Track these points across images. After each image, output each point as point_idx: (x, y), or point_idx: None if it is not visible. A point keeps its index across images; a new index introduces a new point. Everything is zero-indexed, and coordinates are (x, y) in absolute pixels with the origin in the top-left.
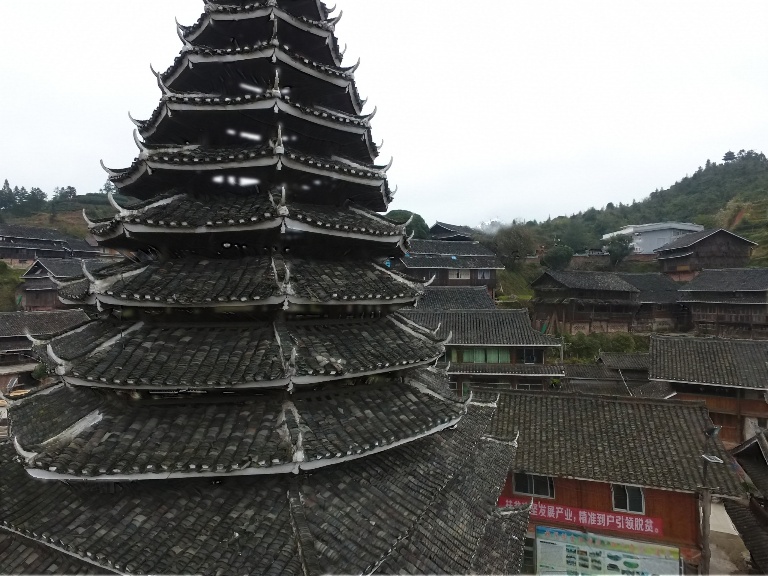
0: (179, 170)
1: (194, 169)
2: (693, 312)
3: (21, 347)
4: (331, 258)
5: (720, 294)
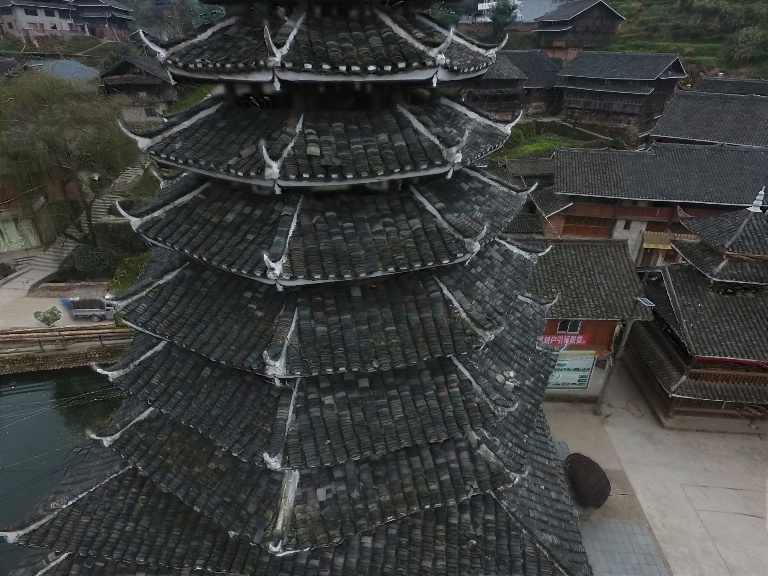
0: (320, 186)
1: (341, 184)
2: (566, 97)
3: None
4: None
5: (592, 80)
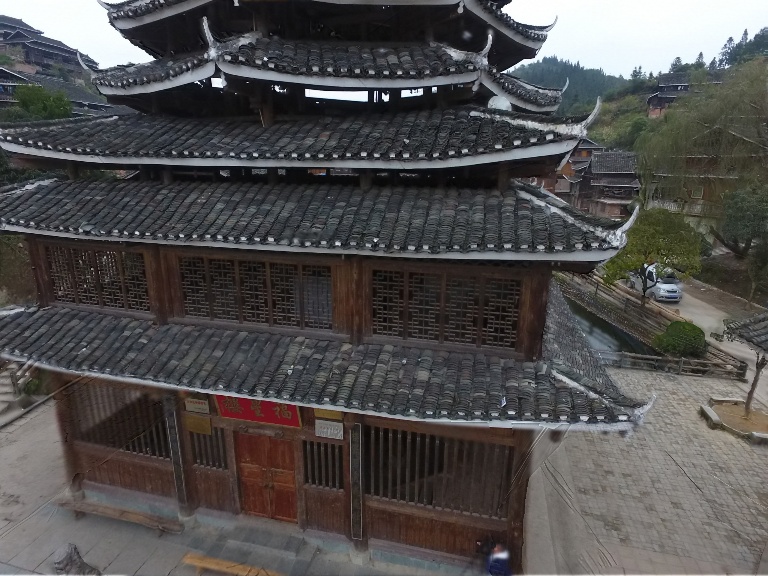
0: None
1: None
2: None
3: None
4: None
5: None
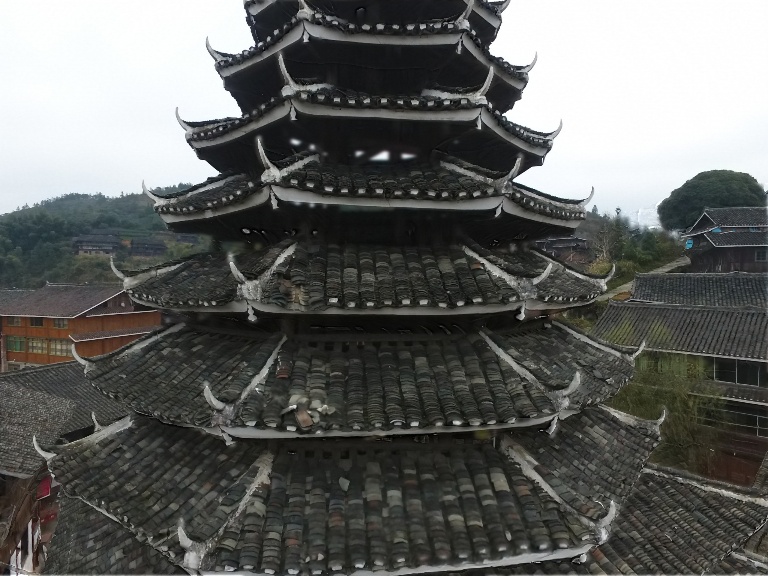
0: (215, 145)
1: (225, 141)
2: None
3: None
4: (391, 241)
5: None
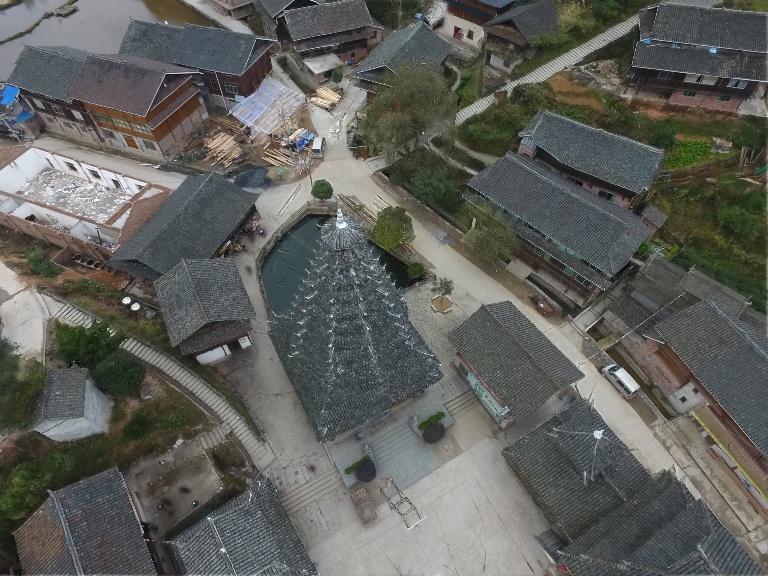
0: None
1: None
2: None
3: (325, 44)
4: None
5: None
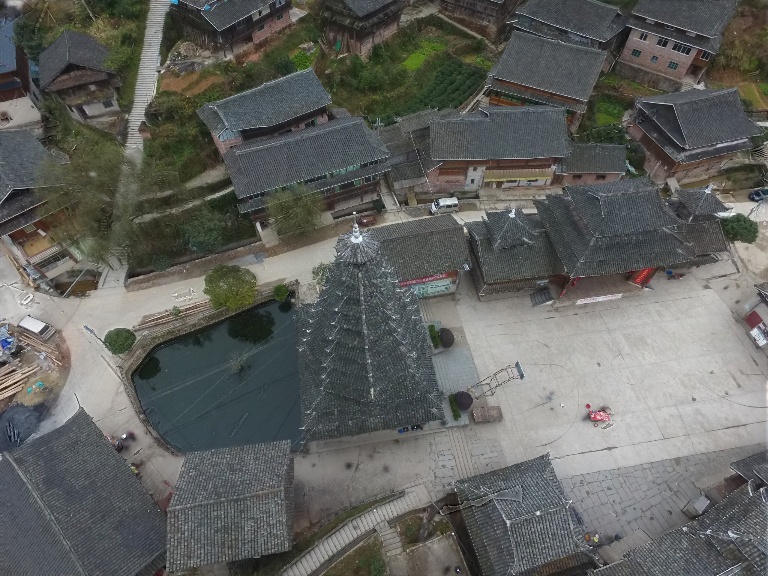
0: None
1: None
2: None
3: None
4: None
5: None
